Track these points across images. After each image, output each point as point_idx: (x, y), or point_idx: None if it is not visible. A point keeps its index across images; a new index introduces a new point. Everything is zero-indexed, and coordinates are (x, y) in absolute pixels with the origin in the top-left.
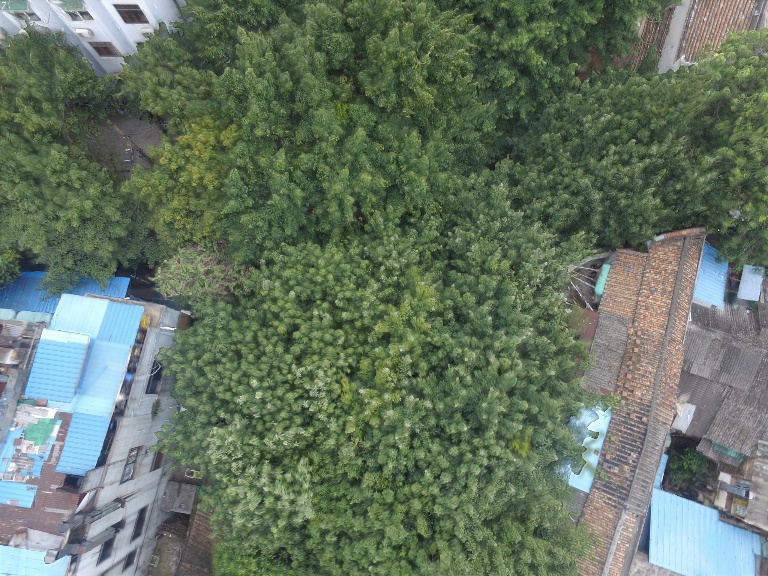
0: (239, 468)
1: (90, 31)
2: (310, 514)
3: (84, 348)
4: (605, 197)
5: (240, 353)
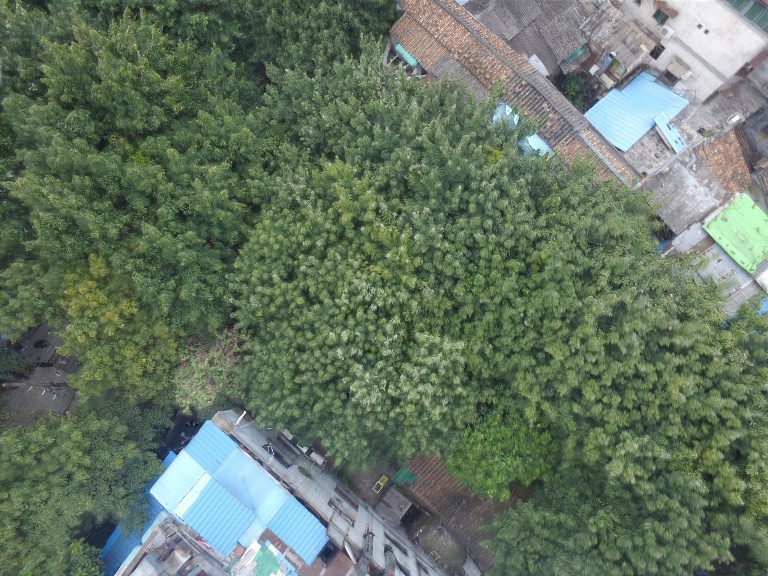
0: (395, 390)
1: None
2: (461, 344)
3: (214, 482)
4: (344, 6)
5: (300, 348)
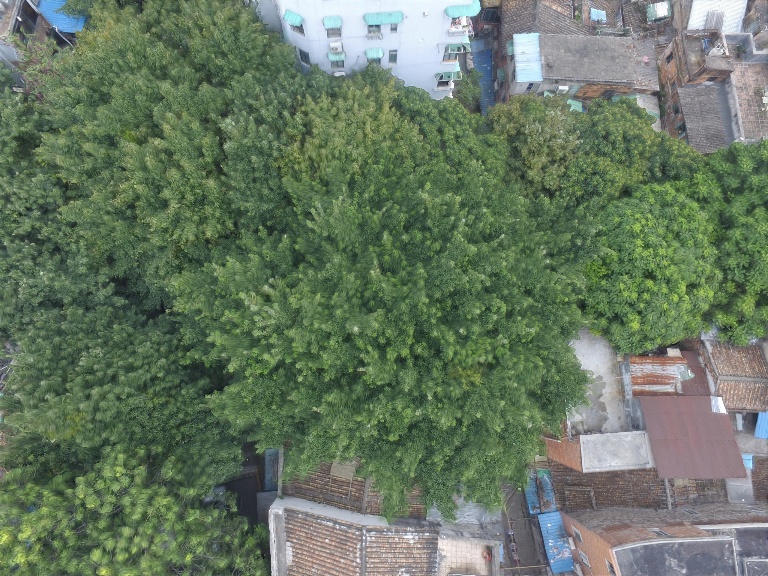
0: None
1: None
2: None
3: None
4: None
5: None
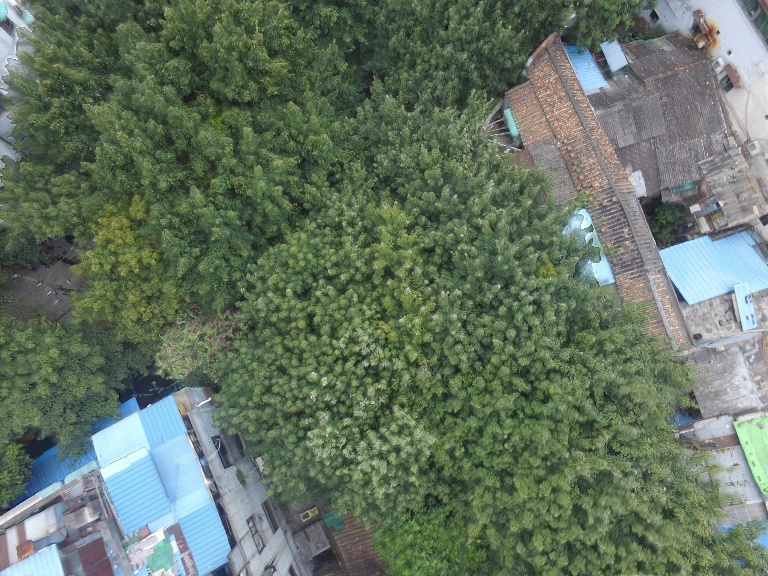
0: (351, 452)
1: None
2: (432, 439)
3: (148, 459)
4: (470, 55)
5: (282, 368)
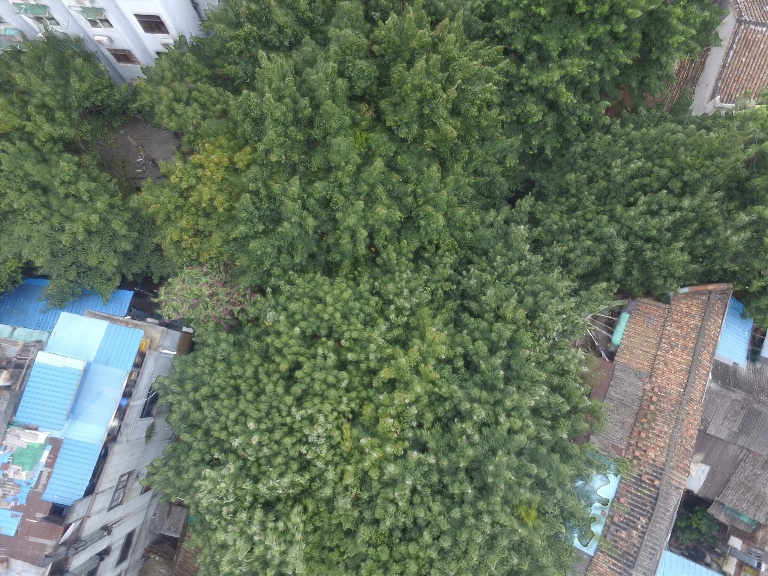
0: (230, 512)
1: (109, 38)
2: (300, 569)
3: (79, 374)
4: (630, 246)
5: (239, 388)
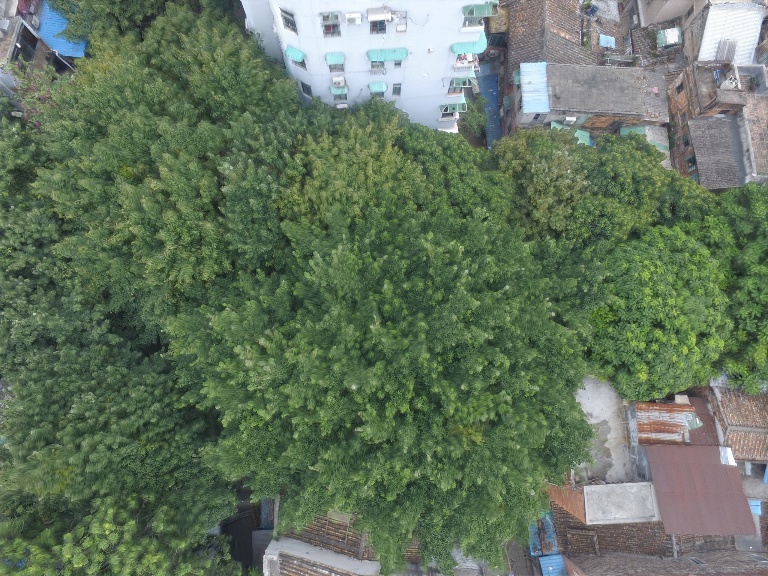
0: None
1: None
2: None
3: None
4: None
5: None
